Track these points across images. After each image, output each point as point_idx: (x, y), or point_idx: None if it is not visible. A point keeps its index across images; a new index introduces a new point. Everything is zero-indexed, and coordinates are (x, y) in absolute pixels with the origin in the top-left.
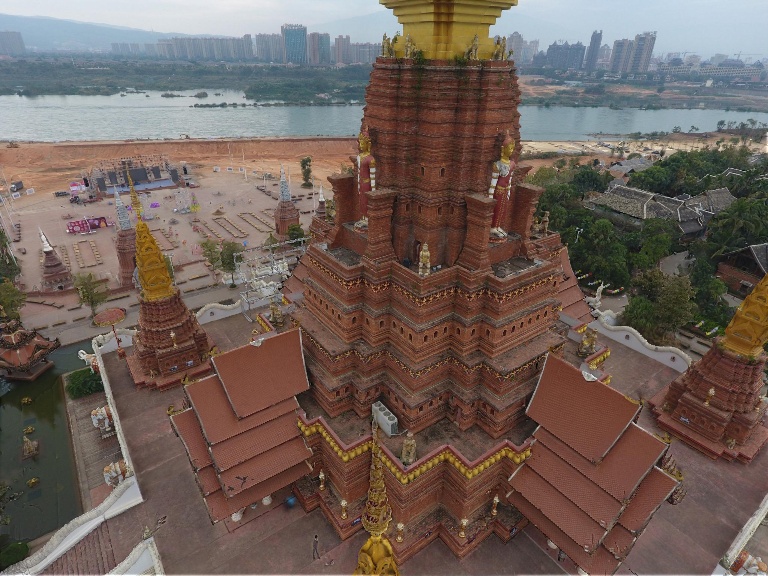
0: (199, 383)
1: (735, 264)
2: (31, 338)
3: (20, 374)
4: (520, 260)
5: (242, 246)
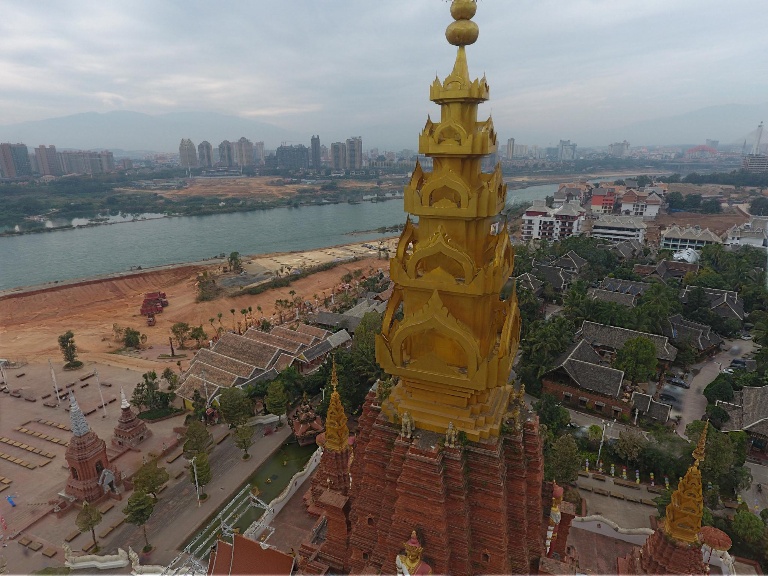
0: None
1: (553, 379)
2: None
3: None
4: None
5: (66, 570)
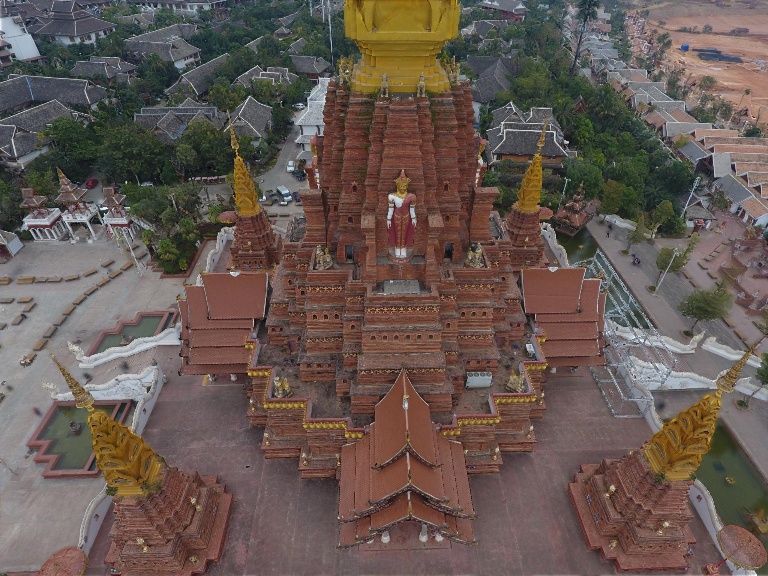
0: None
1: None
2: (575, 212)
3: None
4: None
5: (719, 308)
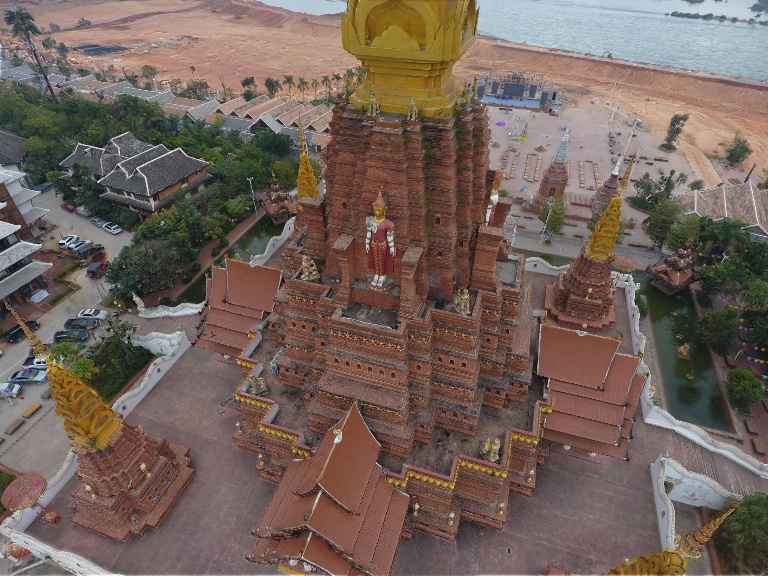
0: (220, 269)
1: None
2: (283, 200)
3: (273, 218)
4: (392, 315)
5: None
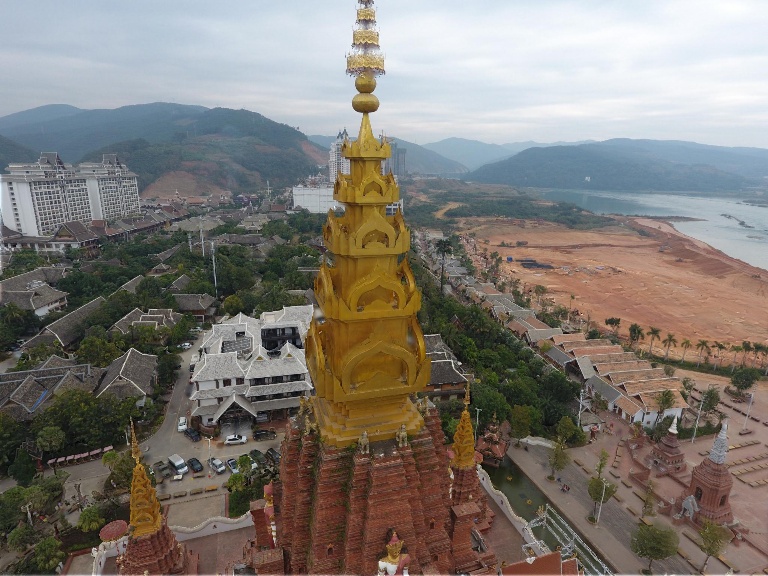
0: None
1: None
2: (495, 443)
3: None
4: None
5: (670, 546)
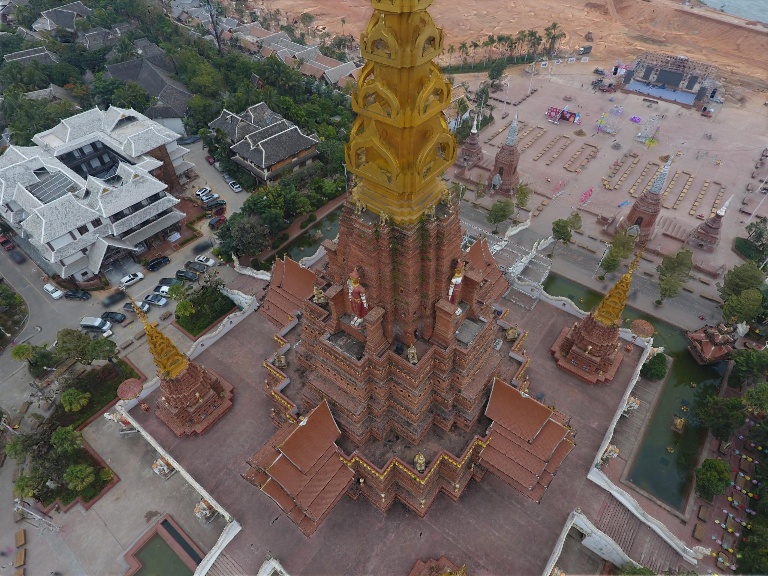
0: (281, 262)
1: None
2: None
3: None
4: (361, 348)
5: (511, 210)
